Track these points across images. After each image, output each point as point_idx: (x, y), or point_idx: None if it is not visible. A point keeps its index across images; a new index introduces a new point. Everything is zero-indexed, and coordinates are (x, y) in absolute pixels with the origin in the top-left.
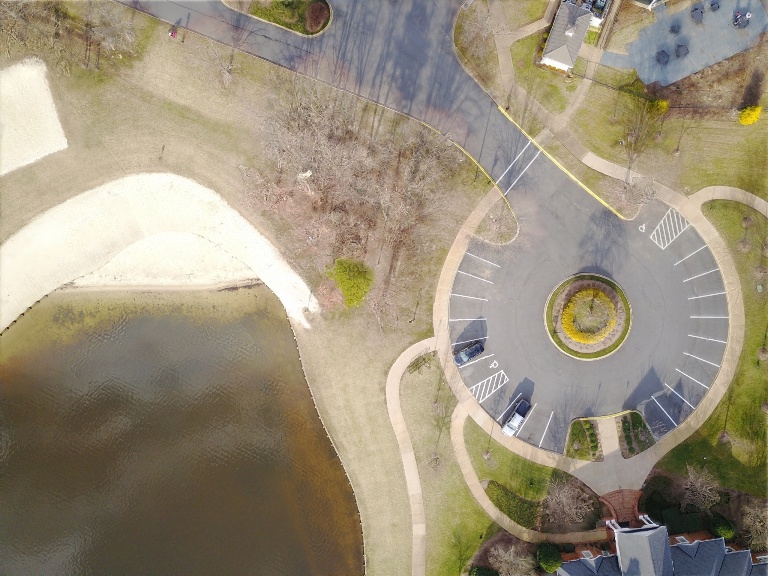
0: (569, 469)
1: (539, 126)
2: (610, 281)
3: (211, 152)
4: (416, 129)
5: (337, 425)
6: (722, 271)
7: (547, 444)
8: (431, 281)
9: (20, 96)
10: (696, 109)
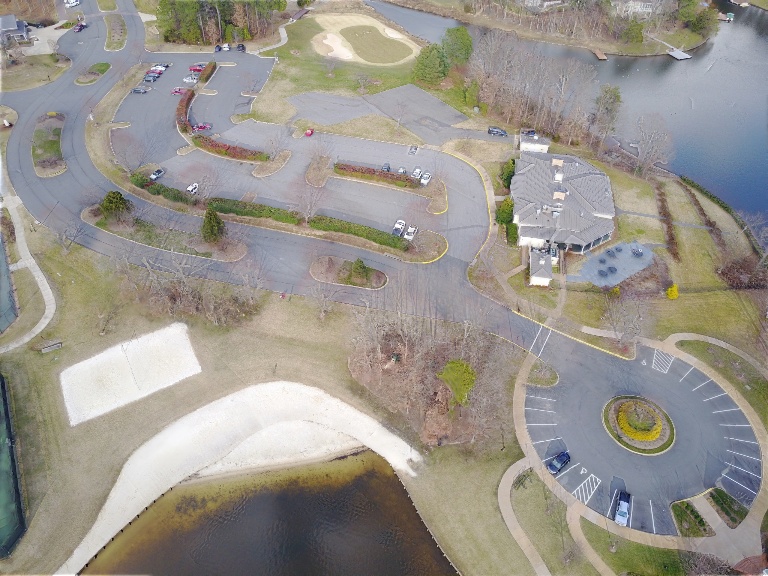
0: (691, 548)
1: (544, 317)
2: (641, 397)
3: (313, 363)
4: None
5: (463, 558)
6: (715, 380)
7: (660, 529)
8: (507, 418)
9: (165, 346)
10: (638, 295)
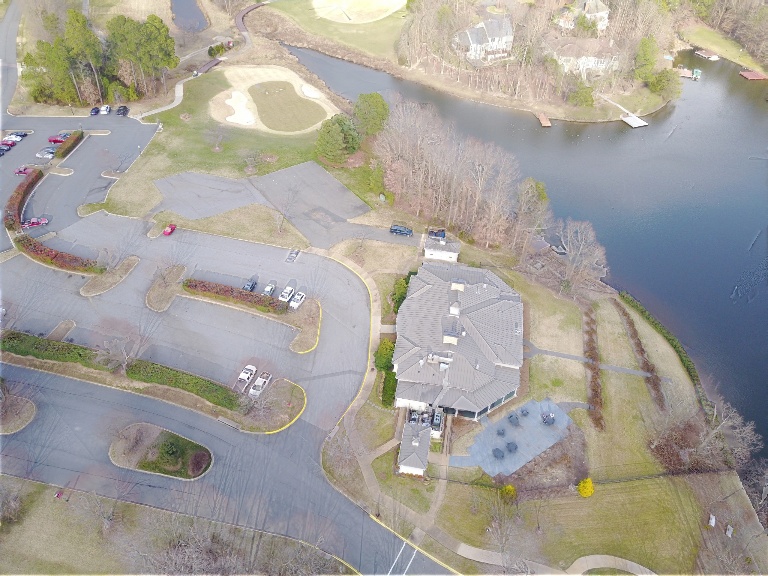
0: None
1: (410, 527)
2: None
3: None
4: (294, 548)
5: None
6: None
7: None
8: None
9: None
10: (541, 490)
